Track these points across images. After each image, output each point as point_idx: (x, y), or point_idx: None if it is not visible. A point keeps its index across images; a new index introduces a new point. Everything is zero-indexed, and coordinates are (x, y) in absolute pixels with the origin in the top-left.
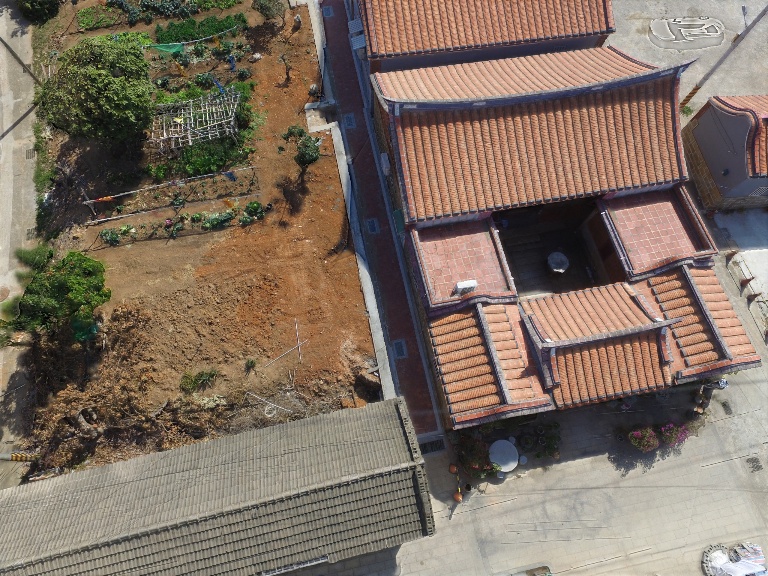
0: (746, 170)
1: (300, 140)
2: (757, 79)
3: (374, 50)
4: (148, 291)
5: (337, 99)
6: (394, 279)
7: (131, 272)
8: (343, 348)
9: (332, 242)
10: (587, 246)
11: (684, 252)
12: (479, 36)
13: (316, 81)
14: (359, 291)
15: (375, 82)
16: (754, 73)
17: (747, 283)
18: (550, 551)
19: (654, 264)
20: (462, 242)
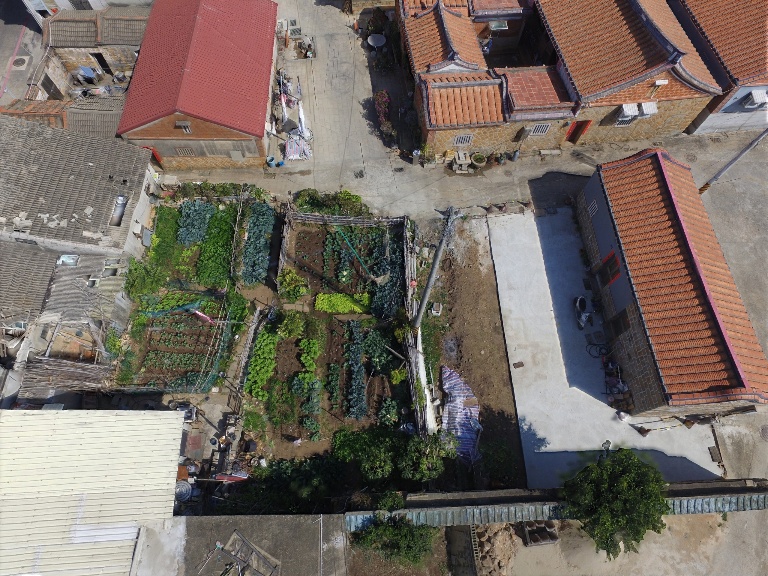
0: None
1: None
2: (760, 290)
3: None
4: None
5: None
6: None
7: None
8: None
9: None
10: None
11: None
12: None
13: None
14: None
15: None
16: None
17: None
18: (323, 61)
19: None
20: None
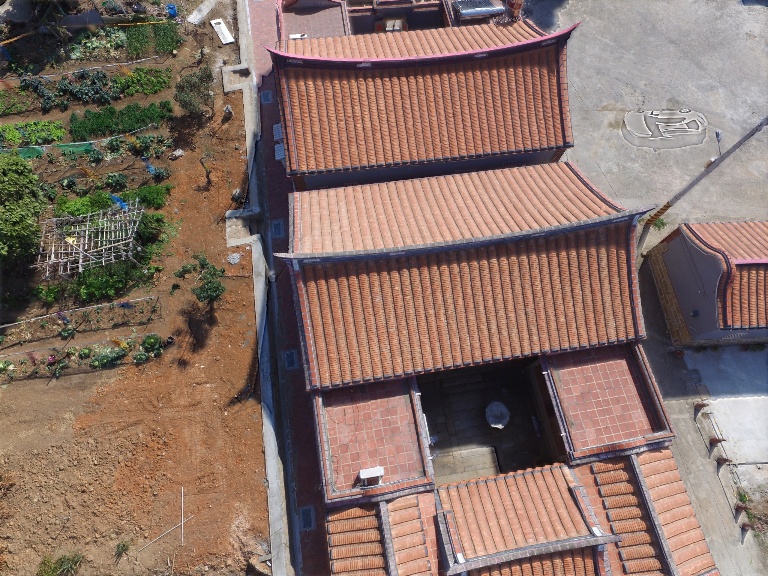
0: (716, 320)
1: (200, 275)
2: (741, 186)
3: (293, 167)
4: (18, 446)
5: (266, 202)
6: (309, 428)
7: (2, 420)
8: (235, 526)
9: (236, 388)
10: (534, 392)
11: (637, 428)
12: (416, 151)
13: (242, 183)
14: (261, 452)
15: (292, 205)
16: (738, 179)
17: (717, 443)
18: None
19: (598, 447)
20: (376, 408)
